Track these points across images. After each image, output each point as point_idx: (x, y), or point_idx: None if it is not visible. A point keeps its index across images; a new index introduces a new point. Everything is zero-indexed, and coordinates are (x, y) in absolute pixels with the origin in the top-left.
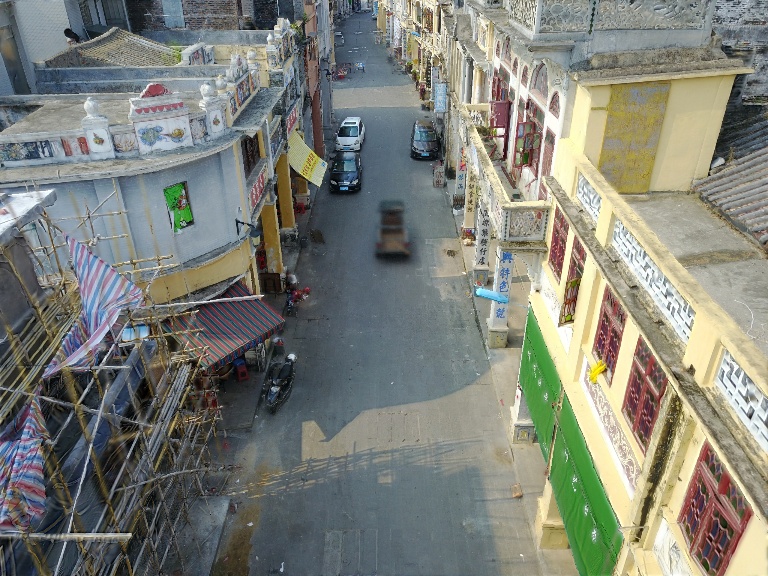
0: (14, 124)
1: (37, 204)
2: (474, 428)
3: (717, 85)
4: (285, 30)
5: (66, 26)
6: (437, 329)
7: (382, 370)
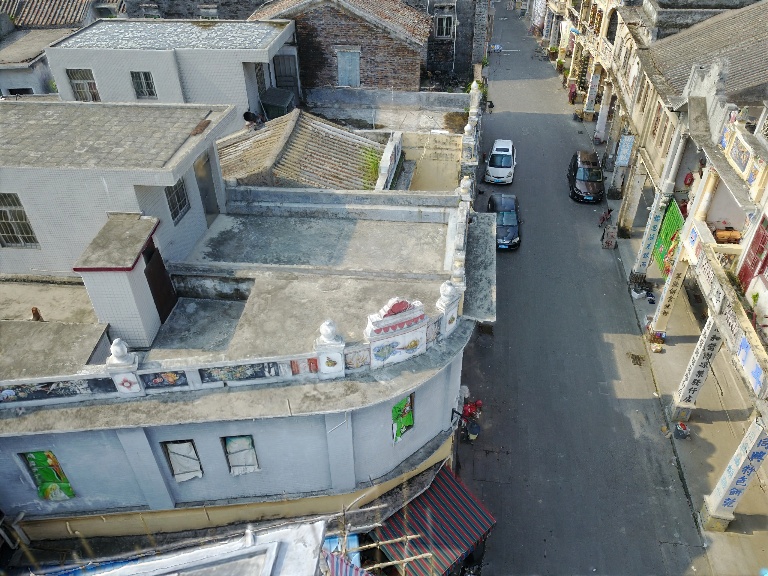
0: (237, 332)
1: (316, 567)
2: None
3: None
4: None
5: (244, 106)
6: (636, 486)
7: (580, 547)
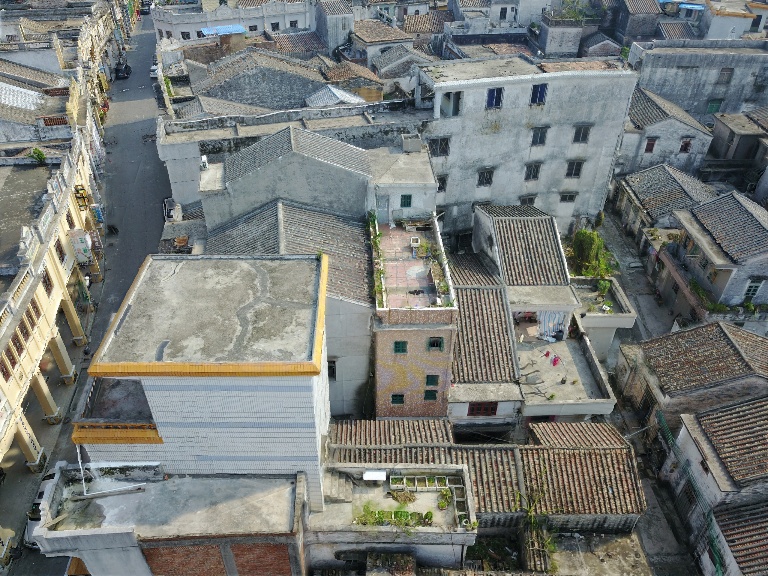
0: None
1: None
2: None
3: None
4: None
5: None
6: None
7: None
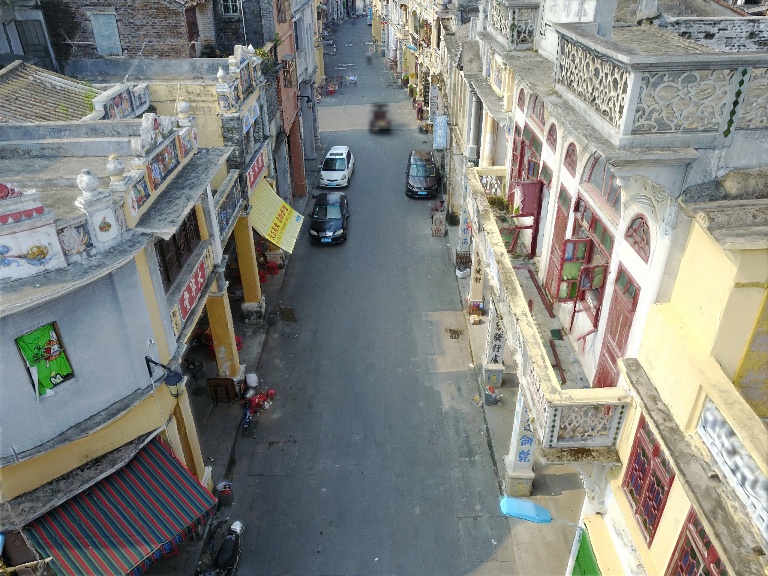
0: None
1: None
2: None
3: None
4: (245, 60)
5: None
6: (438, 460)
7: (363, 535)
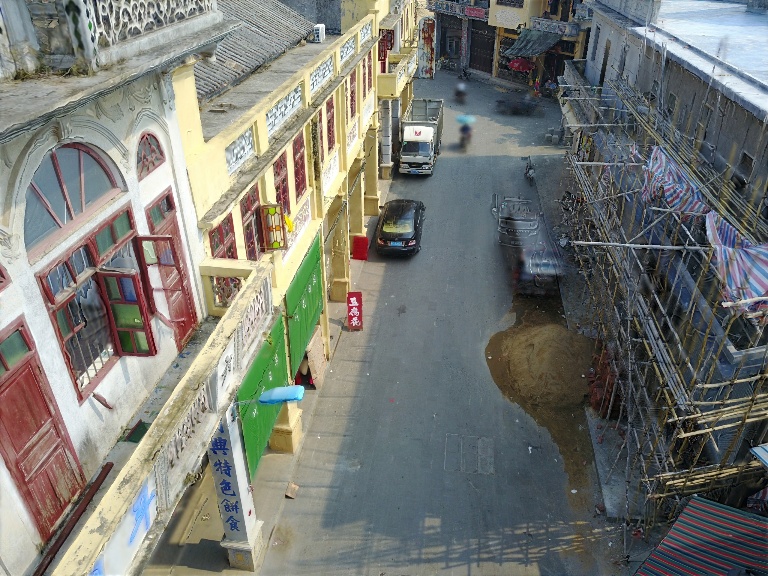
0: None
1: None
2: None
3: None
4: None
5: None
6: None
7: None
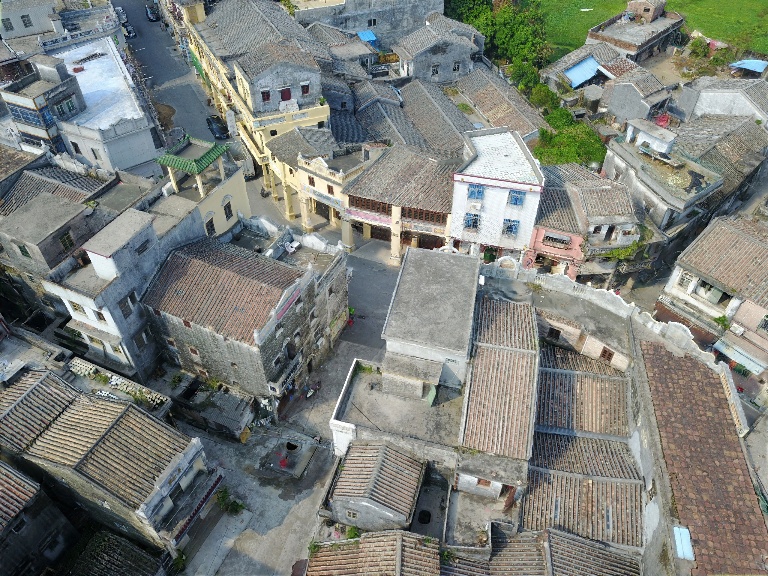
0: None
1: None
2: (190, 79)
3: (201, 5)
4: None
5: None
6: (177, 66)
7: (166, 75)
